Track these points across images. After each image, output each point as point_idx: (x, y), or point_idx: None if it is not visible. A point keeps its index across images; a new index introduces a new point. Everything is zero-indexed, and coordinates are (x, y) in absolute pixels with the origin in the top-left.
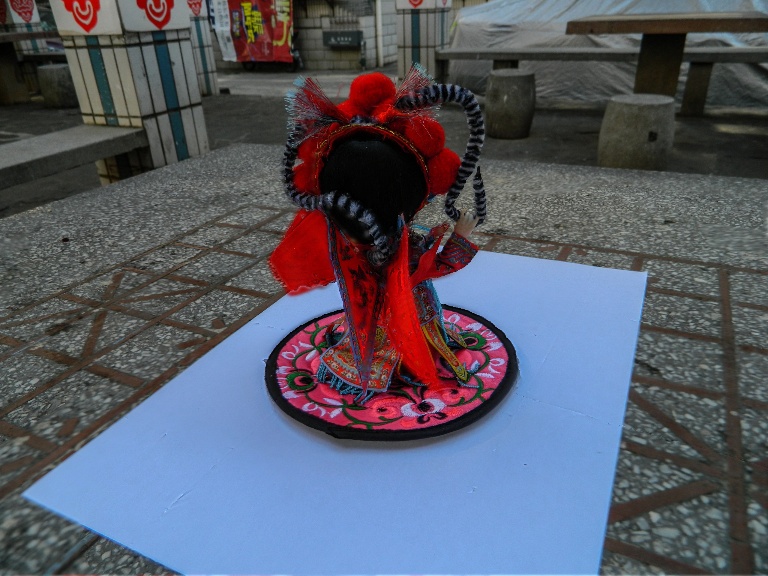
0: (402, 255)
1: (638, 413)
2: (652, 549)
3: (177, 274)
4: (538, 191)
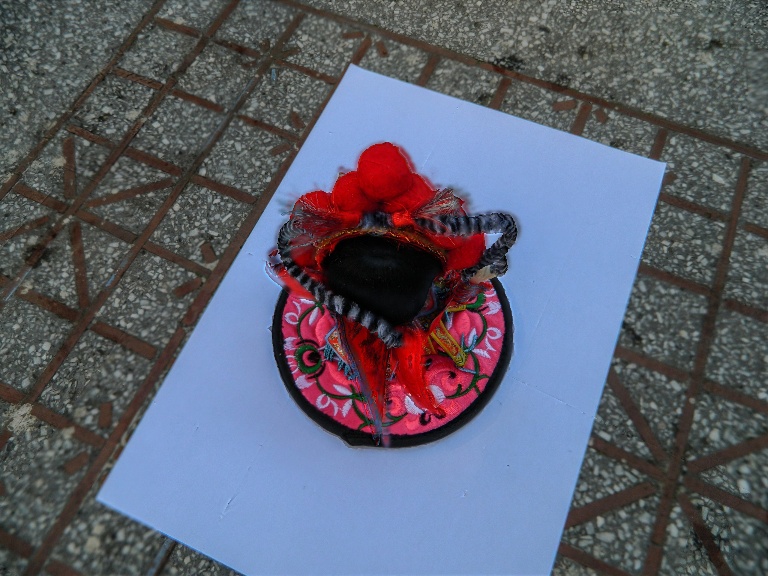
0: (414, 346)
1: (611, 401)
2: (592, 553)
3: (138, 147)
4: None
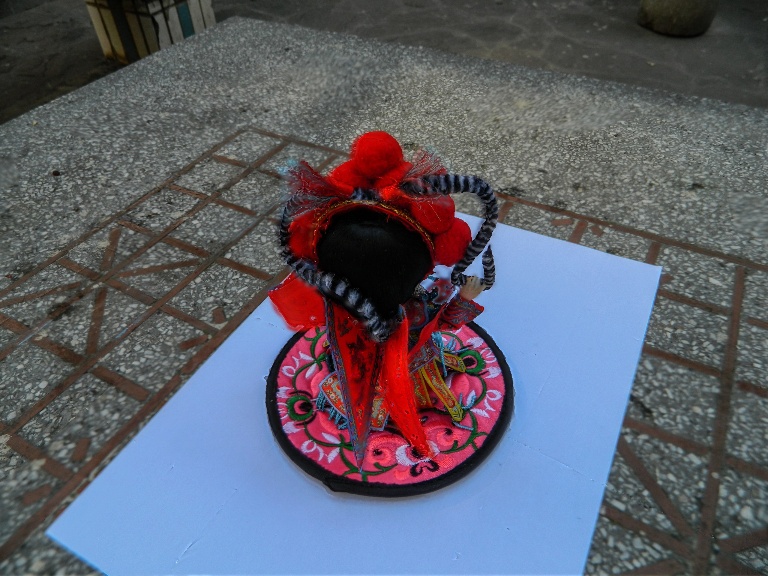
0: (402, 341)
1: (623, 469)
2: None
3: (175, 236)
4: (562, 125)
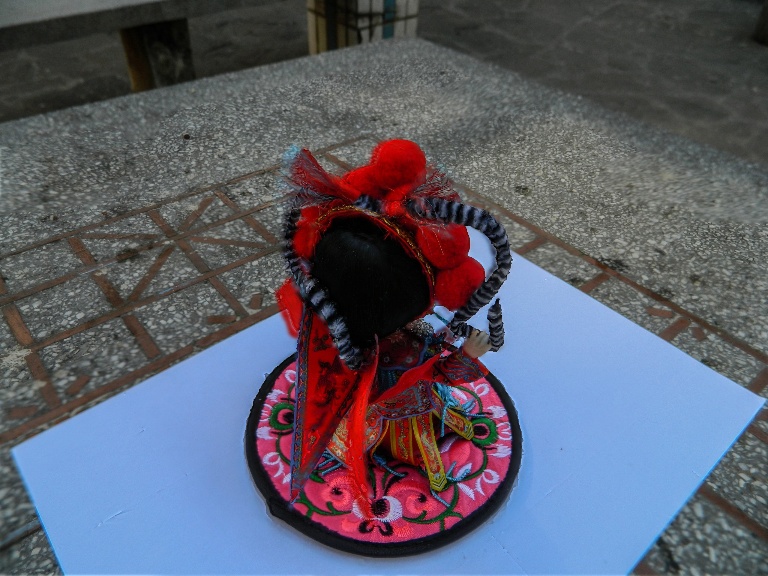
0: (371, 376)
1: None
2: None
3: (256, 217)
4: (706, 209)
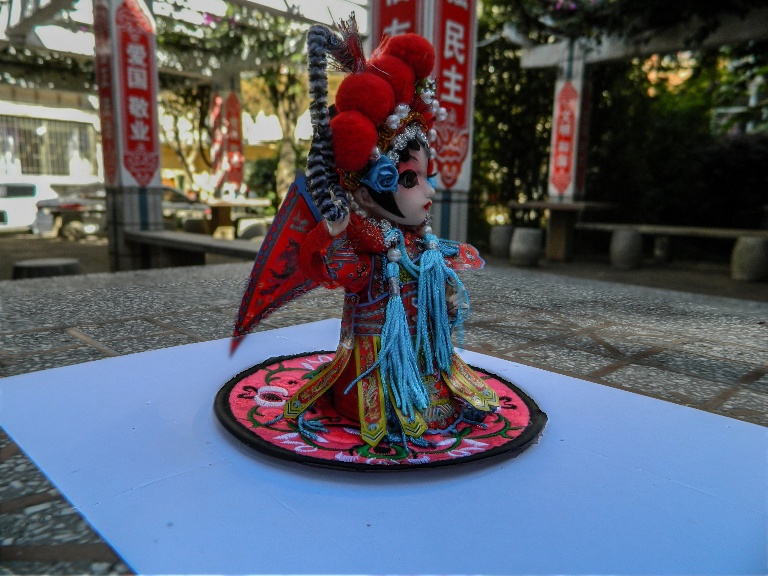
0: (294, 213)
1: (68, 534)
2: None
3: (666, 350)
4: None
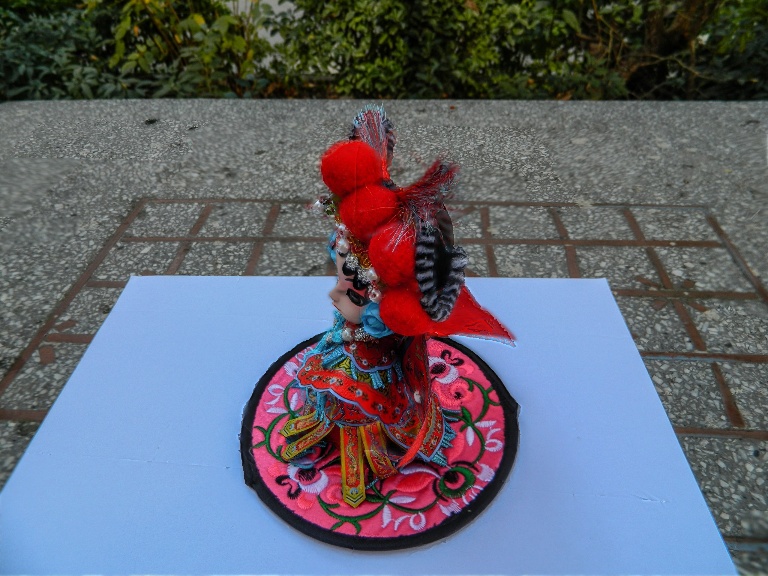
0: None
1: None
2: None
3: None
4: None
